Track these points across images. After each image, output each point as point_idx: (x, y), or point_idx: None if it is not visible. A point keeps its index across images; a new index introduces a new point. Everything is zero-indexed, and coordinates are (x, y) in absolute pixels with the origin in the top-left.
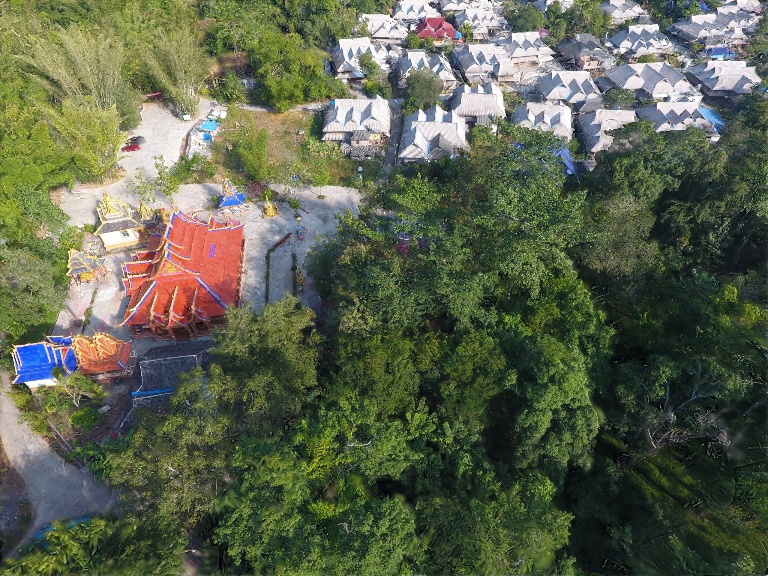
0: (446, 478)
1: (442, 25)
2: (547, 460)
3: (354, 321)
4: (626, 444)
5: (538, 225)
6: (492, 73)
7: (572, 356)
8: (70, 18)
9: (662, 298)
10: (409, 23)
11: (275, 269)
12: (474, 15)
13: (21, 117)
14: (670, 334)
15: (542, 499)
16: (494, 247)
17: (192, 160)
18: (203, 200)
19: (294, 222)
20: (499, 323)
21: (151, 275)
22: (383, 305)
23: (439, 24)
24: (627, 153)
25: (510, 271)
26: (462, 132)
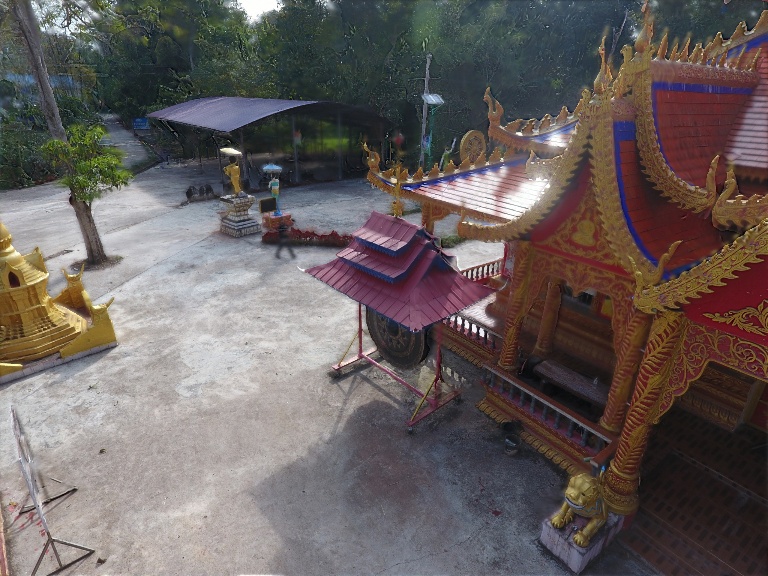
0: None
1: None
2: None
3: None
4: None
5: None
6: None
7: None
8: None
9: None
10: None
11: None
12: None
13: None
14: None
15: None
16: None
17: None
18: None
19: (161, 255)
20: None
21: None
22: None
23: None
24: None
25: None
26: None
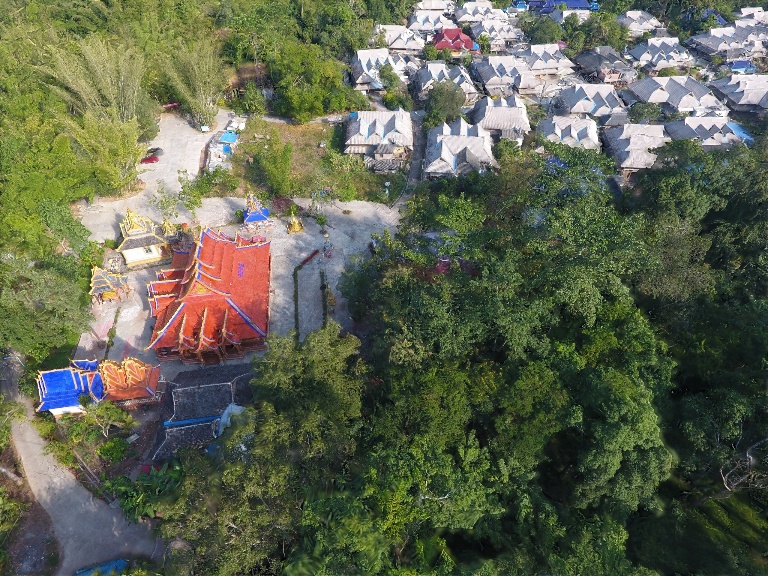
0: (506, 522)
1: (460, 36)
2: (615, 503)
3: (405, 351)
4: (688, 482)
5: (596, 251)
6: (513, 85)
7: (639, 391)
8: (86, 27)
9: (714, 324)
10: (425, 34)
11: (303, 288)
12: (491, 26)
13: (41, 129)
14: (730, 364)
15: (616, 548)
16: (547, 272)
17: (214, 173)
18: (225, 215)
19: (320, 238)
20: (551, 352)
21: (180, 296)
22: (434, 334)
23: (456, 35)
24: (672, 172)
25: (567, 299)
26: (488, 146)
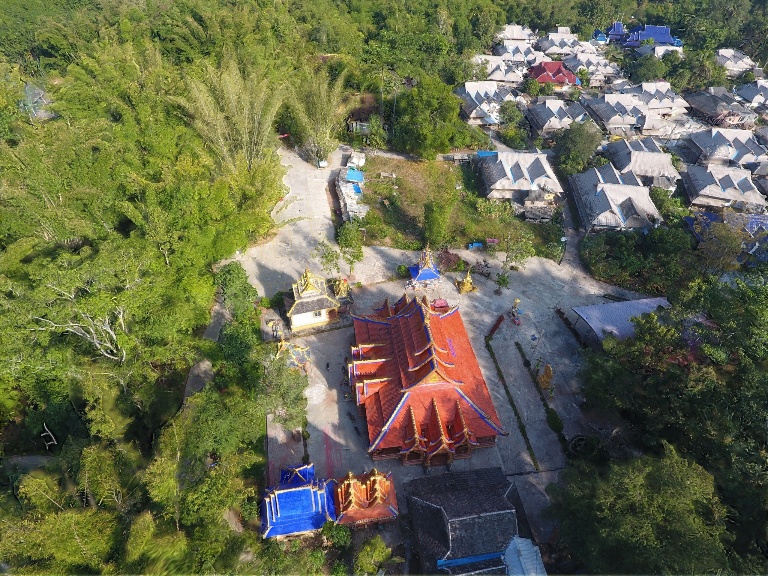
0: None
1: (561, 70)
2: None
3: None
4: None
5: None
6: None
7: None
8: (180, 48)
9: None
10: (517, 65)
11: (505, 364)
12: (586, 60)
13: (191, 171)
14: None
15: None
16: None
17: (366, 221)
18: (380, 268)
19: (498, 300)
20: None
21: (404, 384)
22: None
23: (557, 69)
24: None
25: None
26: None
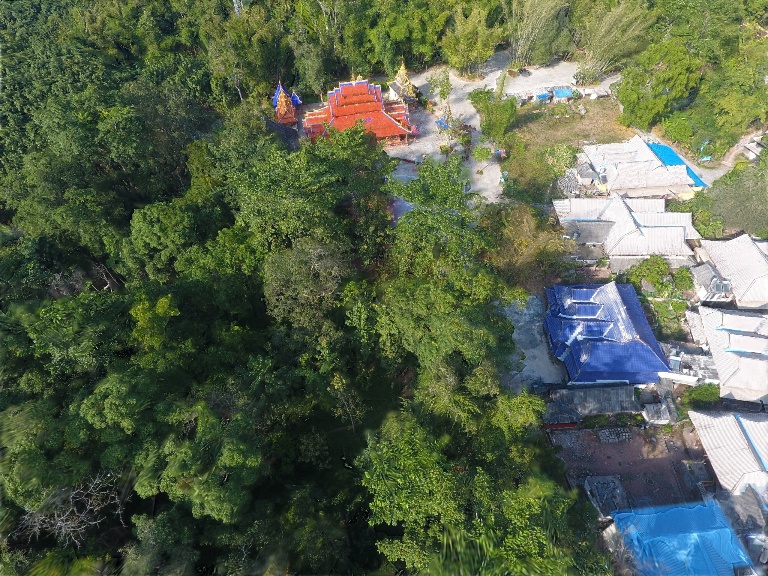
0: None
1: None
2: None
3: None
4: None
5: None
6: None
7: None
8: None
9: None
10: None
11: None
12: None
13: (455, 7)
14: None
15: None
16: None
17: (483, 91)
18: (455, 118)
19: None
20: None
21: None
22: None
23: None
24: None
25: None
26: (643, 248)
